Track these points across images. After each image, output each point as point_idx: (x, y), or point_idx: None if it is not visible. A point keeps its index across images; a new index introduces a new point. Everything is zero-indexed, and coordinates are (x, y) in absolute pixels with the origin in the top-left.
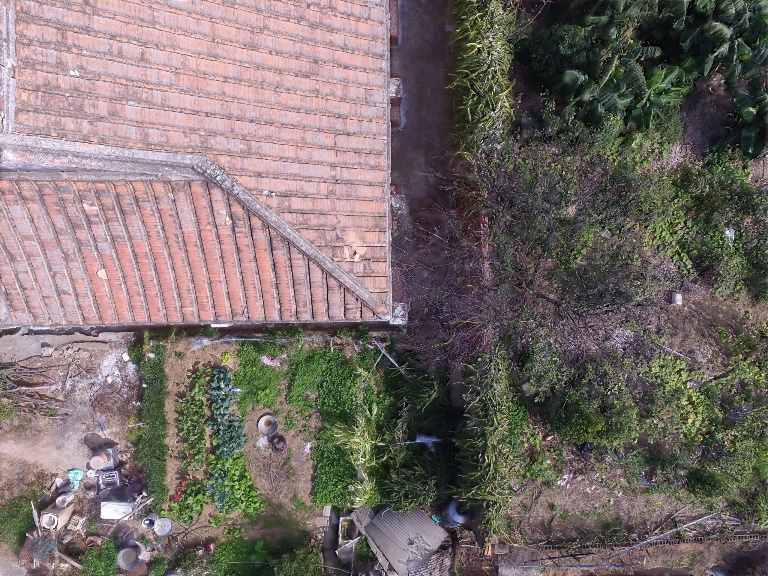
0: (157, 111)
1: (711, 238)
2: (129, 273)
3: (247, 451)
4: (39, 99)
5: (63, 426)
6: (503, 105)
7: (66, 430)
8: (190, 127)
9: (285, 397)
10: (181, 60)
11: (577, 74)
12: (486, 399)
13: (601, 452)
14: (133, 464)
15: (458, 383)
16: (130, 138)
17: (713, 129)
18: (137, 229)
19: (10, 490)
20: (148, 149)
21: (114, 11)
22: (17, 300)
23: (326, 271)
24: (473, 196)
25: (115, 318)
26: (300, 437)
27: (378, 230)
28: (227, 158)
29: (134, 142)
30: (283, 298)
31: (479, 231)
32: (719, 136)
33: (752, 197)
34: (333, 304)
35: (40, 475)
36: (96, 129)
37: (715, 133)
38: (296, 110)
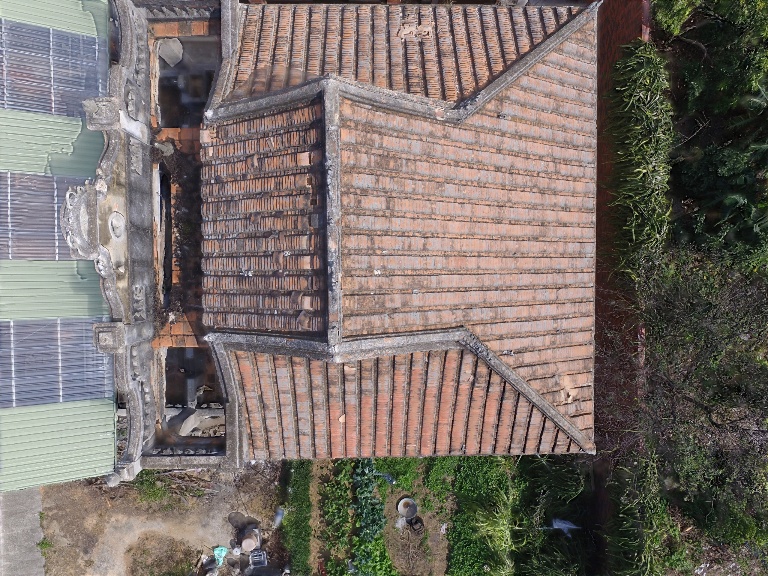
0: (433, 295)
1: None
2: (367, 418)
3: (386, 532)
4: (356, 303)
5: (208, 505)
6: None
7: (211, 509)
8: (455, 304)
9: (423, 480)
10: (450, 244)
11: (738, 199)
12: (644, 502)
13: (738, 544)
14: (274, 541)
15: (612, 483)
16: (416, 324)
17: None
18: (386, 385)
19: (159, 567)
20: (429, 332)
21: (405, 210)
22: (260, 440)
23: (549, 417)
24: (632, 309)
25: (343, 453)
26: (436, 518)
27: (585, 371)
28: (481, 327)
29: (417, 326)
30: (501, 437)
31: (636, 342)
32: None
33: None
34: (546, 441)
35: (187, 552)
36: (394, 321)
37: None
38: (528, 271)
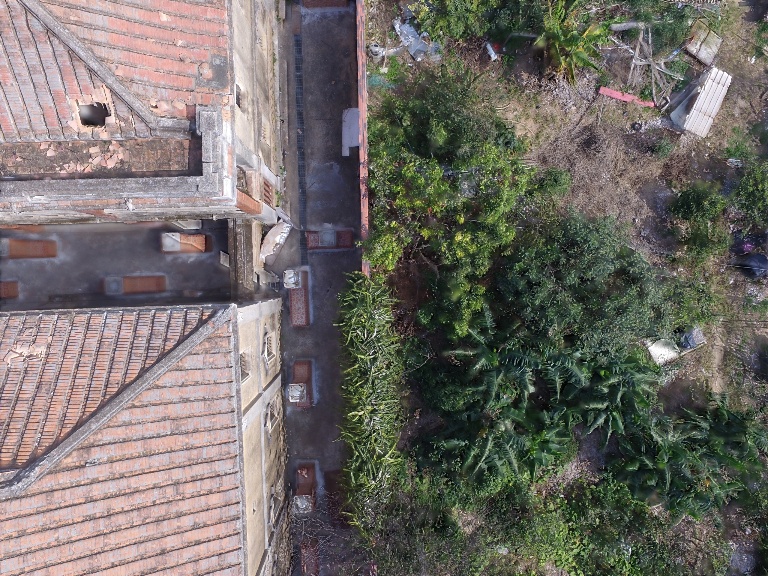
0: None
1: (607, 554)
2: None
3: None
4: None
5: None
6: (387, 463)
7: None
8: None
9: None
10: None
11: (456, 442)
12: None
13: None
14: None
15: None
16: None
17: (608, 448)
18: None
19: None
20: None
21: None
22: None
23: None
24: (361, 547)
25: None
26: None
27: None
28: None
29: None
30: None
31: None
32: (614, 455)
33: (641, 533)
34: None
35: None
36: None
37: (610, 452)
38: None
